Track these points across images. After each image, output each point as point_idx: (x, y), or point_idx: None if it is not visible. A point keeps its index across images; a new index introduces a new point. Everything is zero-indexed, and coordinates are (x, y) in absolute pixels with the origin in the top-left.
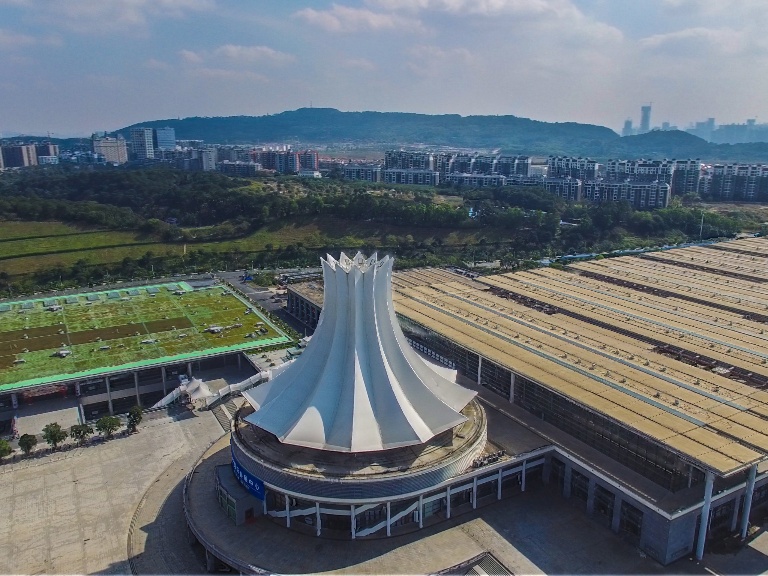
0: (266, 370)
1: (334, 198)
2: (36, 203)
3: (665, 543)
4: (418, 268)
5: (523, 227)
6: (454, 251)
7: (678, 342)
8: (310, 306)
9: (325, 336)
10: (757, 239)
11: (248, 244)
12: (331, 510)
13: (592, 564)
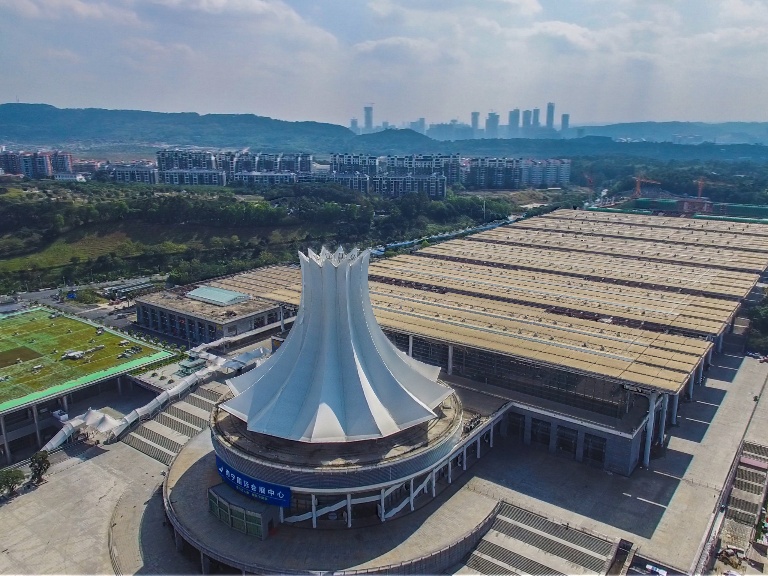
0: (170, 388)
1: (138, 202)
2: None
3: (628, 459)
4: (263, 267)
5: (340, 221)
6: (282, 248)
7: (560, 303)
8: (176, 316)
9: (313, 333)
10: (538, 218)
11: (45, 259)
12: (361, 499)
13: (582, 489)
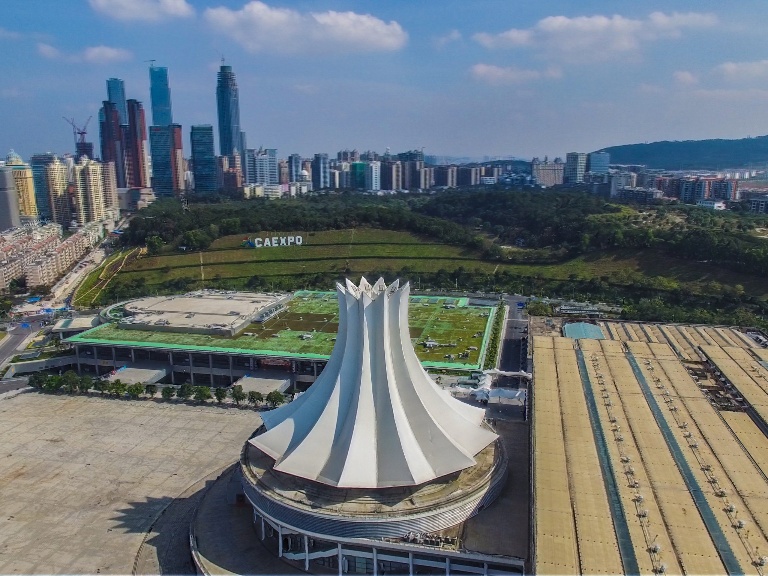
0: None
1: (669, 232)
2: (396, 215)
3: None
4: (706, 325)
5: None
6: None
7: None
8: None
9: None
10: None
11: (557, 271)
12: None
13: None
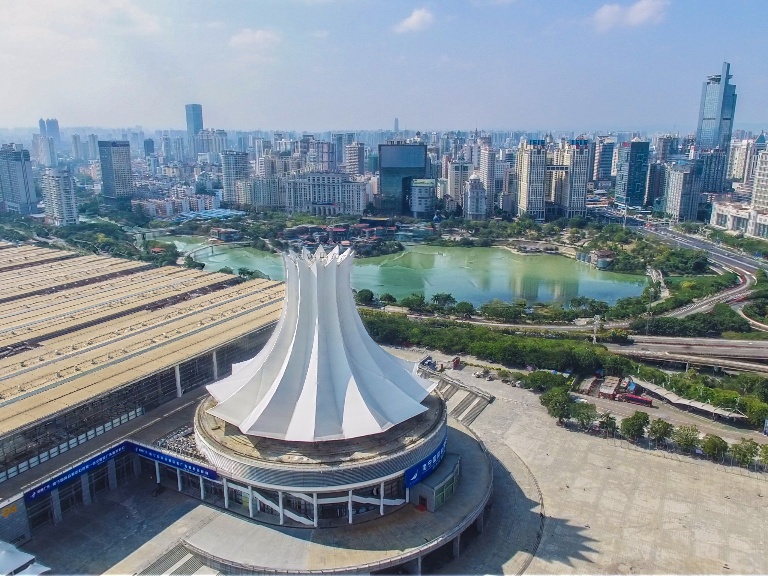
0: None
1: None
2: None
3: None
4: None
5: None
6: None
7: (138, 303)
8: None
9: None
10: None
11: None
12: None
13: None
